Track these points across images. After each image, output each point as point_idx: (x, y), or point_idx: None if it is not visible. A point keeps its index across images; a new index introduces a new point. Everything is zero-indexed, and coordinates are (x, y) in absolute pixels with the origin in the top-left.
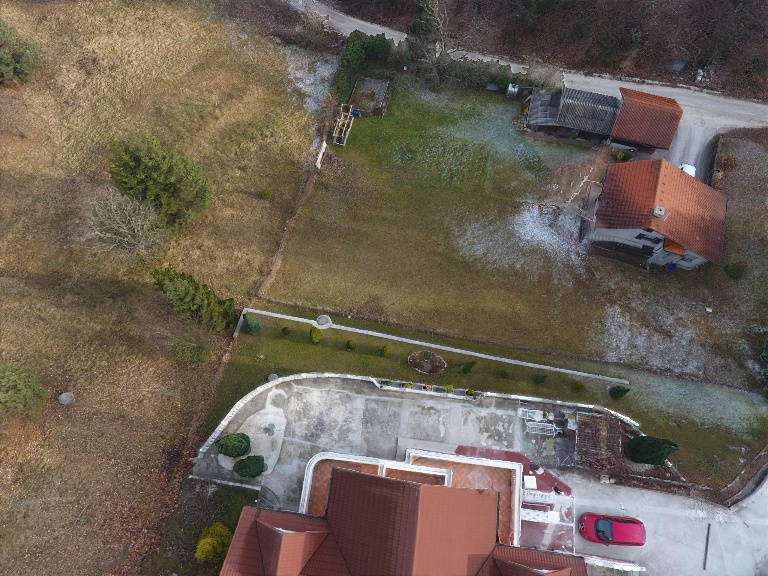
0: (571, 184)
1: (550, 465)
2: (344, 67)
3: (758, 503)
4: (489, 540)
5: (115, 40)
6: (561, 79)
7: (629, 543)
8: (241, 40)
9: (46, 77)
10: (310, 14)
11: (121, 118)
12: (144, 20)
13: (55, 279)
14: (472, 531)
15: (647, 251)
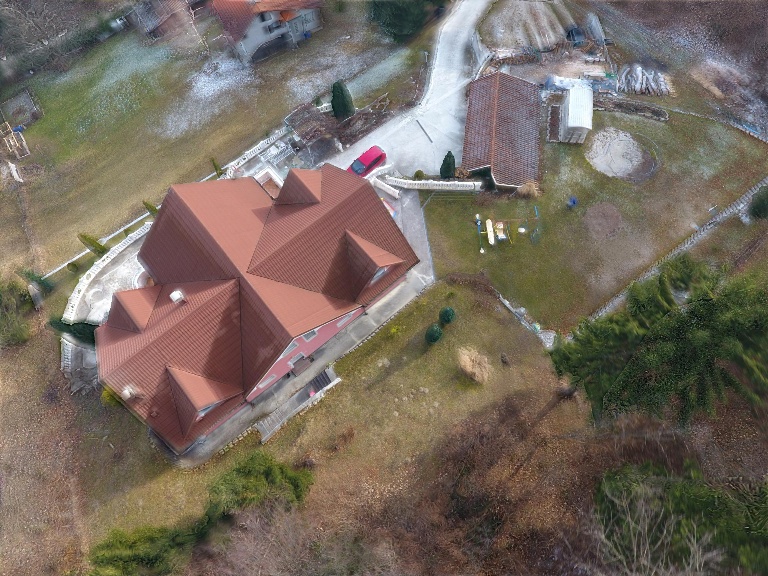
0: None
1: None
2: None
3: (435, 92)
4: (265, 200)
5: None
6: None
7: (377, 161)
8: None
9: None
10: None
11: None
12: None
13: None
14: (244, 199)
15: (284, 35)
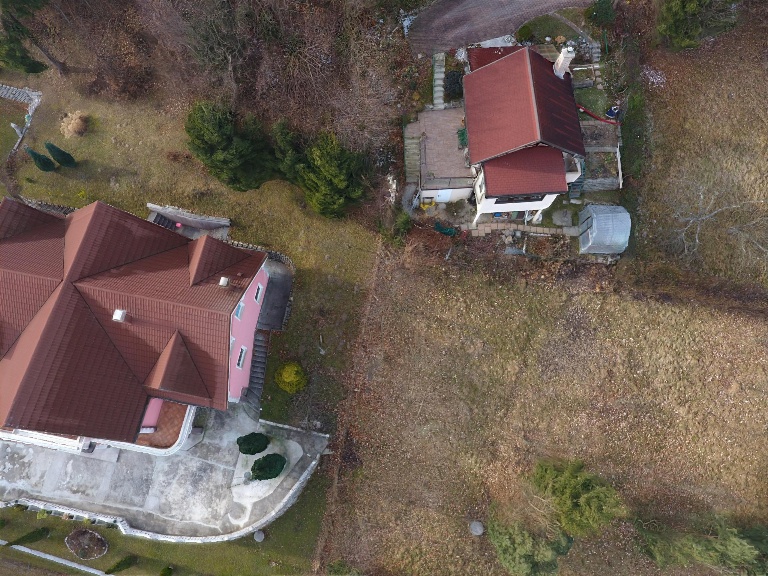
0: None
1: None
2: None
3: None
4: None
5: None
6: None
7: None
8: None
9: None
10: None
11: None
12: None
13: None
14: None
15: None
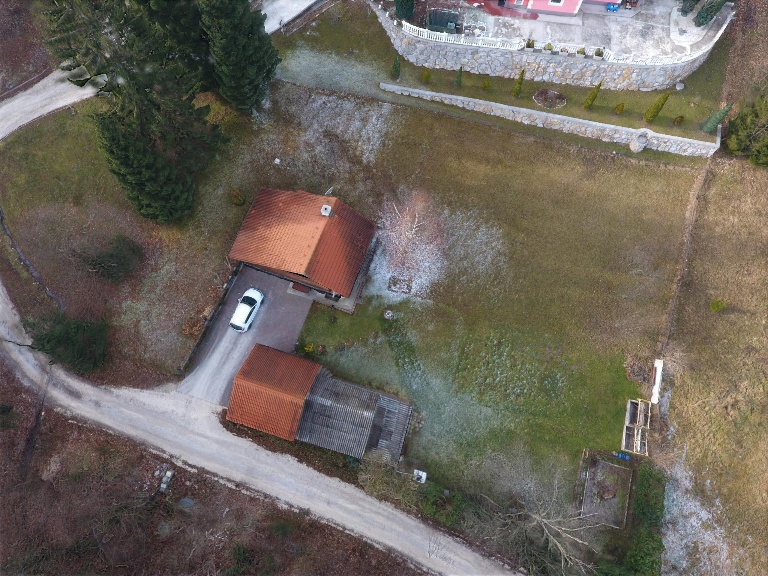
0: None
1: (468, 8)
2: None
3: None
4: None
5: None
6: (362, 472)
7: None
8: None
9: None
10: None
11: None
12: None
13: None
14: None
15: None
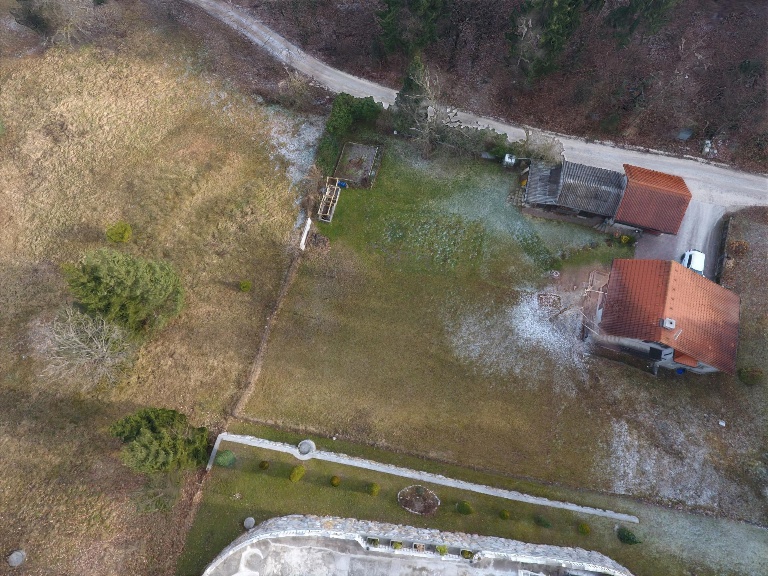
0: (574, 288)
1: None
2: (330, 133)
3: None
4: None
5: (85, 101)
6: (561, 152)
7: None
8: (221, 99)
9: (10, 145)
10: (293, 77)
11: (90, 194)
12: (116, 78)
13: (11, 399)
14: None
15: (655, 356)
